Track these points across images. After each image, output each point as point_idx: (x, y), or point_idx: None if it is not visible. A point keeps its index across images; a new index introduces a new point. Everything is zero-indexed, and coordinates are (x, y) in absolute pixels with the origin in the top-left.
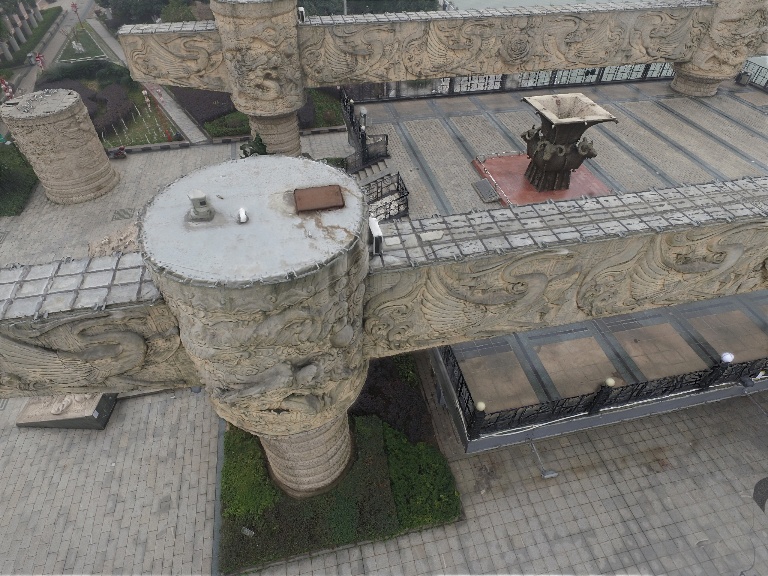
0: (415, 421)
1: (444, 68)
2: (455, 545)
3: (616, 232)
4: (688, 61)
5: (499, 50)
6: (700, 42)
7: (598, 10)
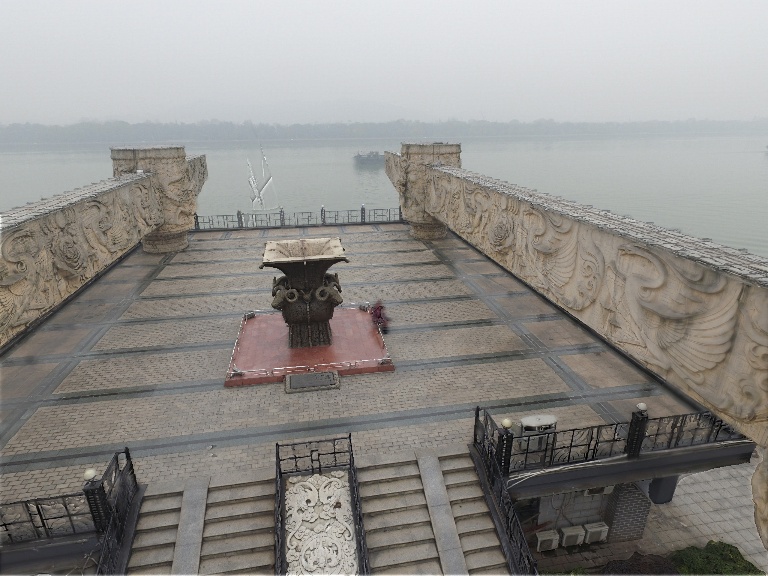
0: (660, 569)
1: (7, 323)
2: (762, 559)
3: (649, 224)
4: (163, 223)
5: (55, 264)
6: (162, 205)
7: (105, 190)
